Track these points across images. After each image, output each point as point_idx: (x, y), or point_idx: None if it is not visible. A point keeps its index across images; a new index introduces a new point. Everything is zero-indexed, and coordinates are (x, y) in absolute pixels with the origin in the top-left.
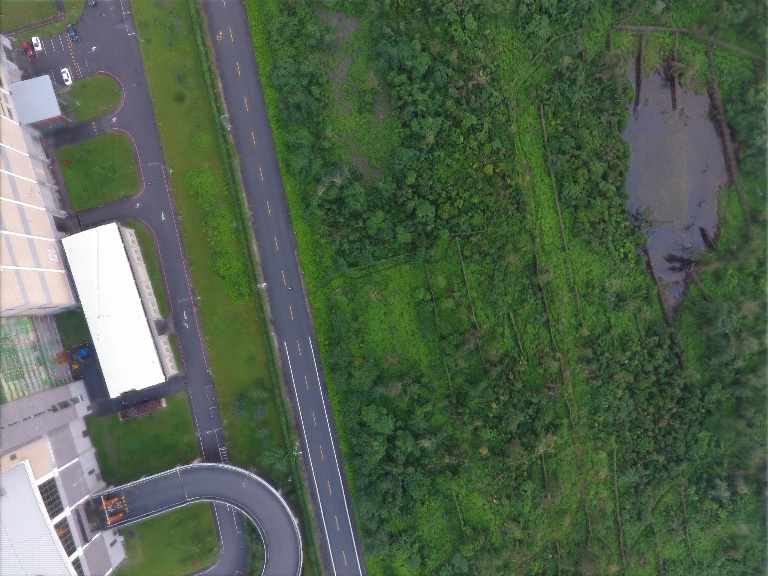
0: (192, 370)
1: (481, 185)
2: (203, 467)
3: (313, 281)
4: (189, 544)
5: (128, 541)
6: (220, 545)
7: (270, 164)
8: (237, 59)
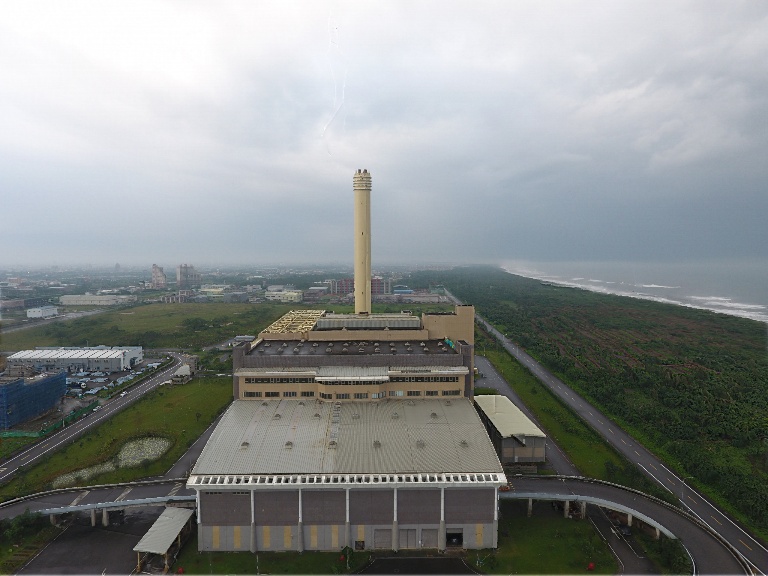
0: (557, 463)
1: (765, 421)
2: (588, 482)
3: (650, 444)
4: (577, 551)
5: (501, 538)
6: (618, 563)
7: (596, 412)
8: (565, 391)
